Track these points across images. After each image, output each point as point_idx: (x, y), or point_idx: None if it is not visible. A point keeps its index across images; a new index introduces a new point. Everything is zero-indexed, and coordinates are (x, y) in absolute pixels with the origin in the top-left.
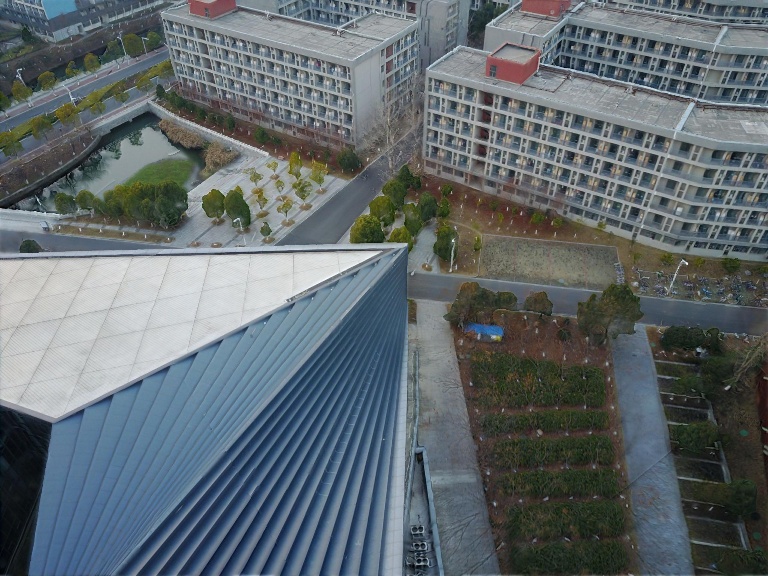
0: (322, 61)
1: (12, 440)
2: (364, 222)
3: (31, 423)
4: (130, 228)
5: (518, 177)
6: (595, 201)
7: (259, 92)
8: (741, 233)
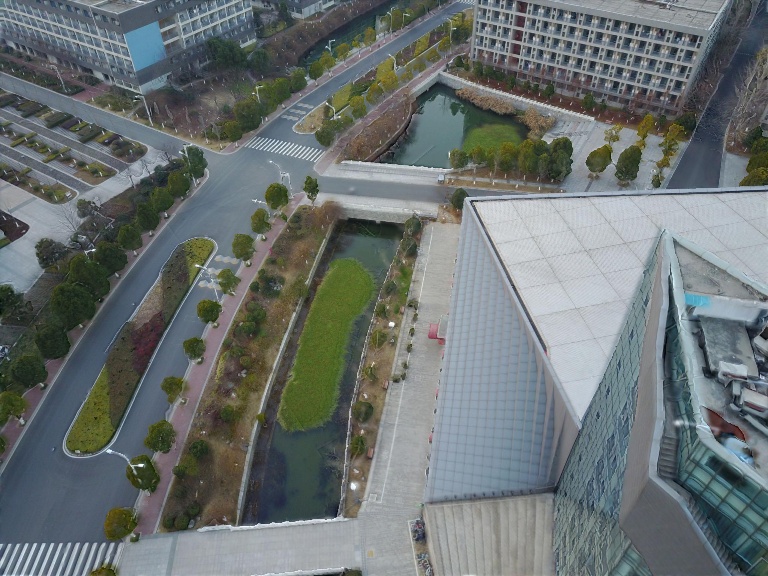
0: (669, 31)
1: None
2: (767, 173)
3: None
4: (517, 181)
5: None
6: None
7: (573, 62)
8: None
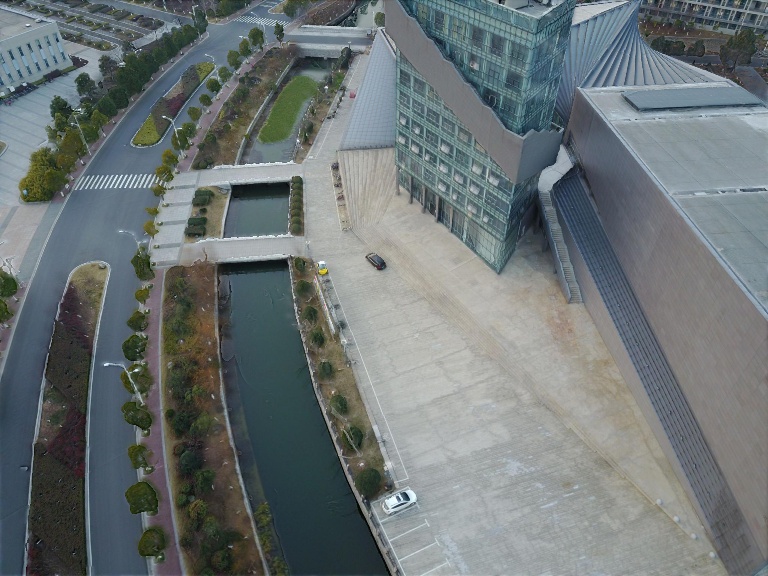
0: None
1: None
2: None
3: None
4: None
5: (661, 2)
6: (712, 12)
7: None
8: None
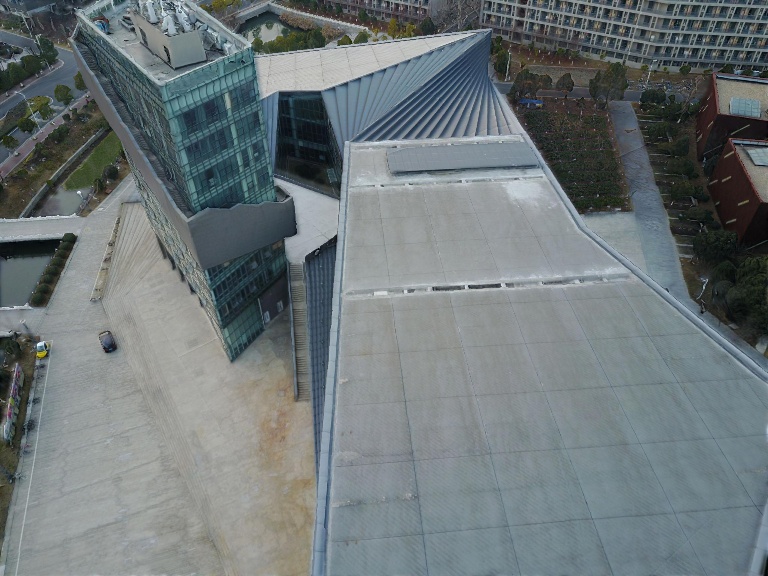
0: None
1: (281, 122)
2: None
3: (300, 102)
4: None
5: (547, 29)
6: (598, 40)
7: None
8: (692, 52)
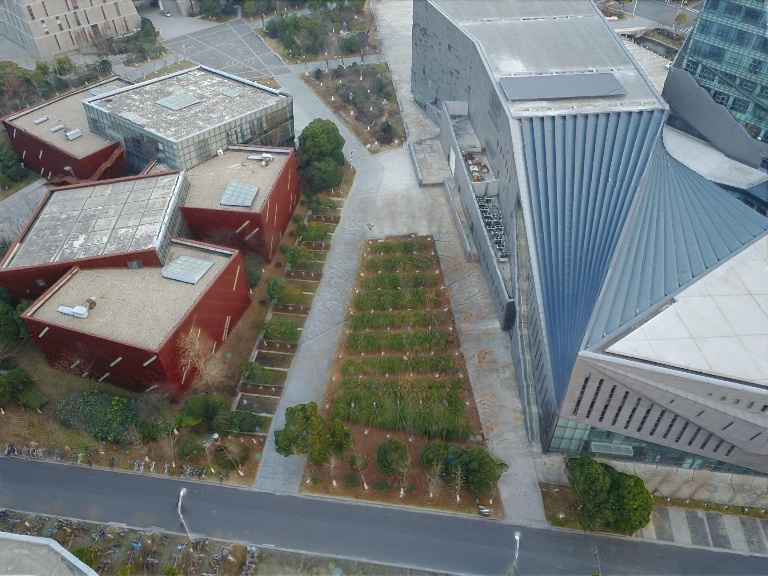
0: None
1: None
2: None
3: None
4: None
5: None
6: None
7: None
8: None
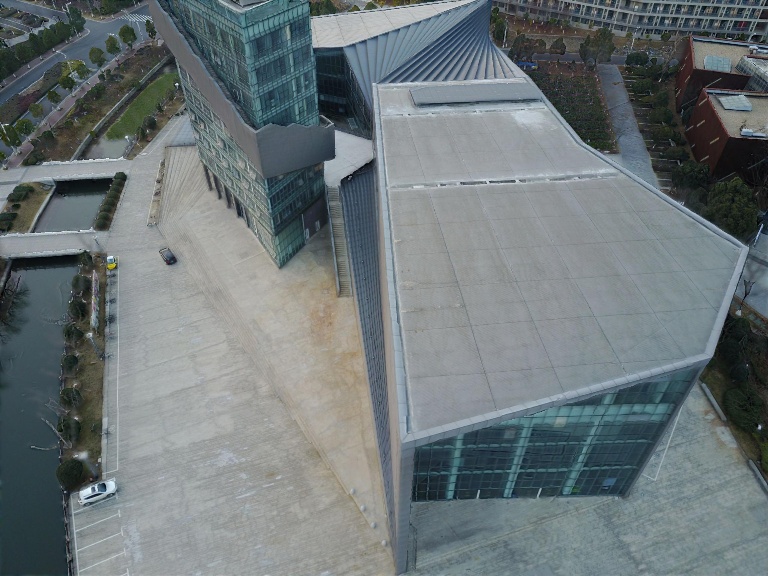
0: None
1: None
2: None
3: (323, 58)
4: None
5: (540, 1)
6: (587, 11)
7: None
8: (672, 21)
